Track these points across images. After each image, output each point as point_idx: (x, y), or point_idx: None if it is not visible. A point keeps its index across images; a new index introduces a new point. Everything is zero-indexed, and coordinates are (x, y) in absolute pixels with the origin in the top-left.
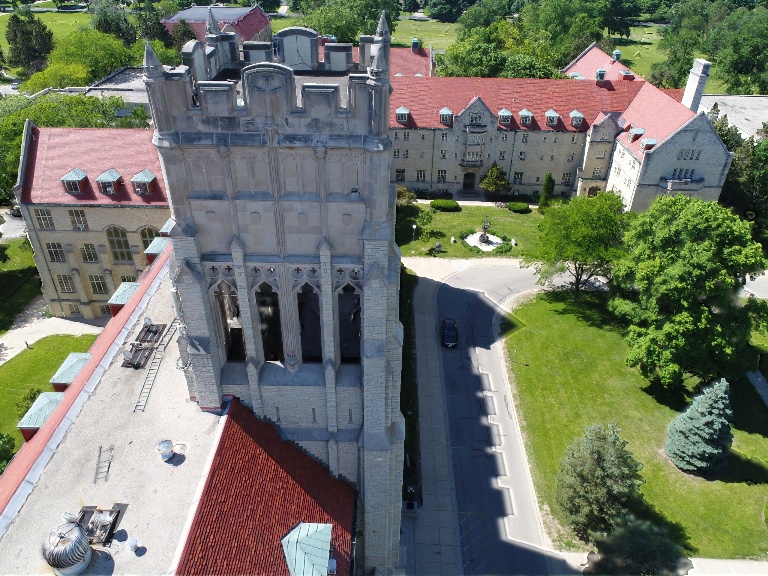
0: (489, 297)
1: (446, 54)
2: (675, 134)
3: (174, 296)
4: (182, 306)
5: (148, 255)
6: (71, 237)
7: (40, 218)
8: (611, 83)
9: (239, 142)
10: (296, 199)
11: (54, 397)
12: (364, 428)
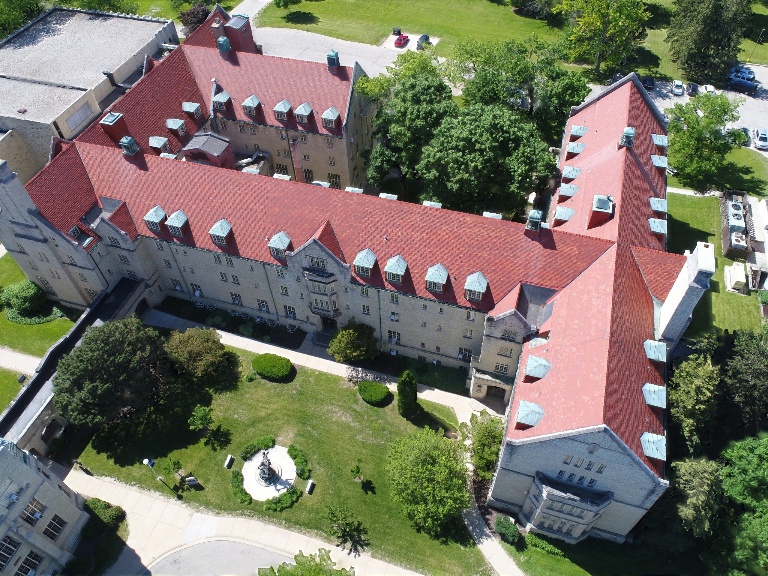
0: None
1: None
2: (554, 438)
3: None
4: None
5: None
6: None
7: None
8: (552, 235)
9: None
10: None
11: None
12: None
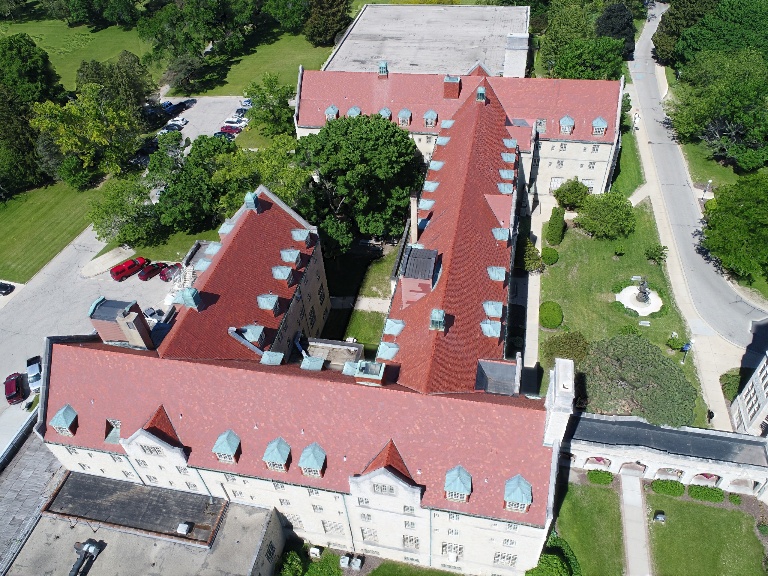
0: (761, 319)
1: None
2: None
3: None
4: None
5: None
6: None
7: None
8: None
9: None
10: None
11: None
12: None
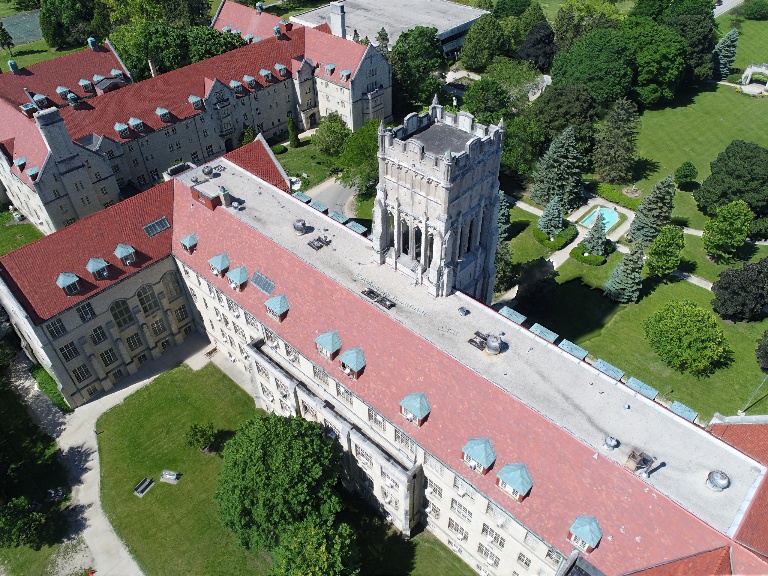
0: None
1: (128, 44)
2: (361, 63)
3: None
4: None
5: (241, 285)
6: (82, 330)
7: (52, 330)
8: (286, 35)
9: (467, 172)
10: (477, 185)
11: None
12: None
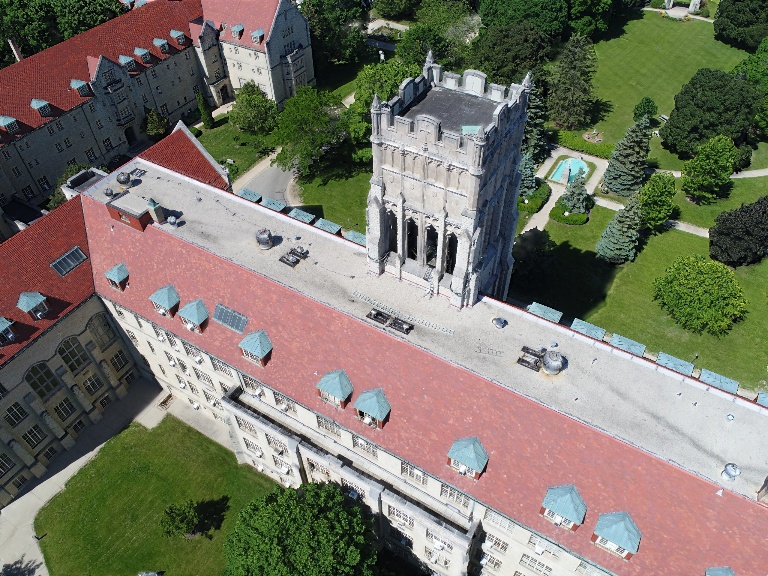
0: None
1: None
2: (275, 20)
3: (474, 251)
4: (474, 254)
5: (201, 325)
6: None
7: None
8: None
9: (496, 150)
10: None
11: (371, 395)
12: (507, 259)
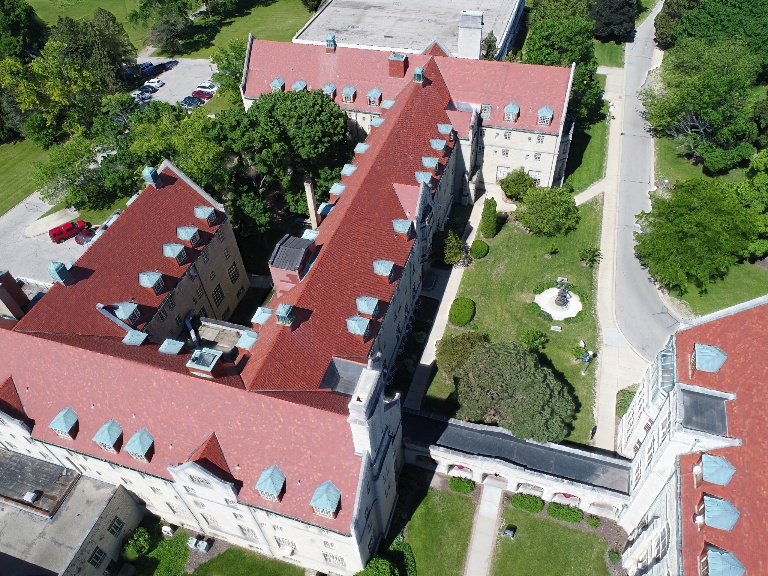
0: None
1: (202, 158)
2: None
3: None
4: None
5: None
6: None
7: None
8: (425, 77)
9: None
10: None
11: None
12: None
